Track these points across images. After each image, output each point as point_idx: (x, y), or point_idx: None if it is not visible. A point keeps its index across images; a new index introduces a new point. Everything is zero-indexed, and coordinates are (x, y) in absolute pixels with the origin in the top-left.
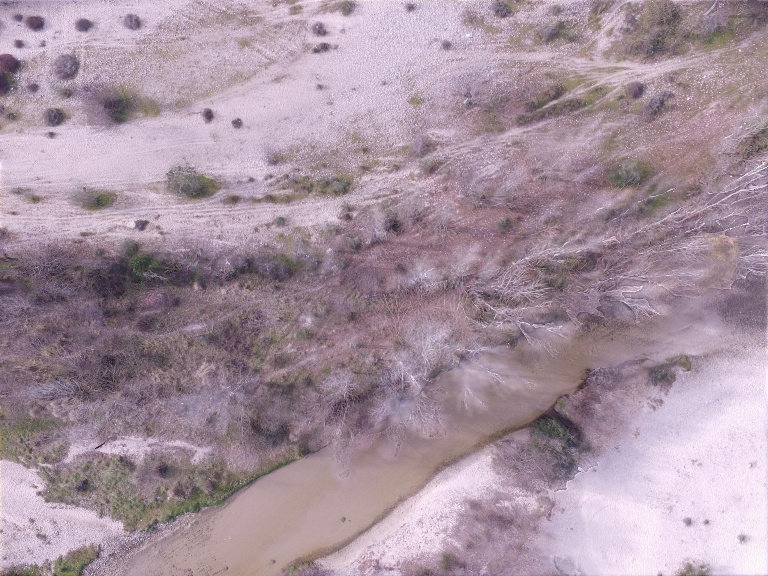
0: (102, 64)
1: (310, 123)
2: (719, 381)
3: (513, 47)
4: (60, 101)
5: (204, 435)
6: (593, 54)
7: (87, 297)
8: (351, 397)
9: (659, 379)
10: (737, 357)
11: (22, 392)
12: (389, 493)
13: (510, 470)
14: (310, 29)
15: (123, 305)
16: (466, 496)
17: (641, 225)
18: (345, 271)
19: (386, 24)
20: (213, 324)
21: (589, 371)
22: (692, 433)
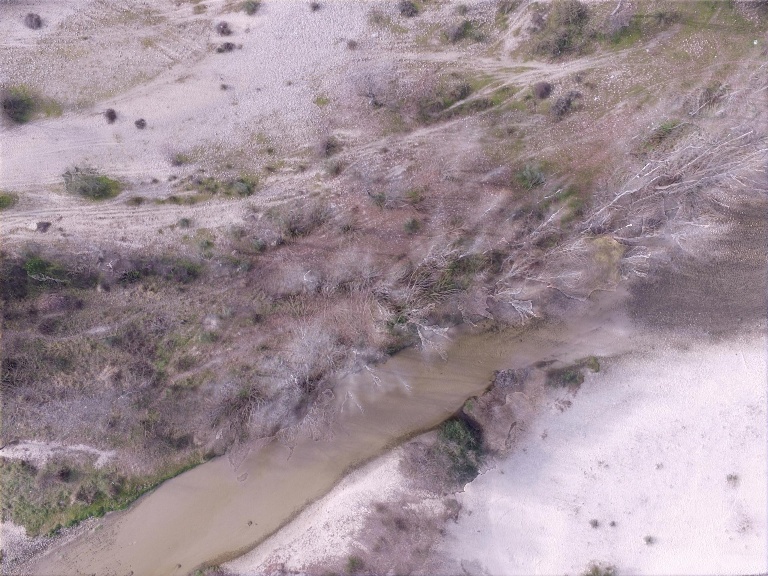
0: (3, 64)
1: (214, 124)
2: (627, 382)
3: (420, 47)
4: None
5: (108, 439)
6: (500, 54)
7: None
8: (256, 400)
9: (568, 380)
10: (645, 358)
11: None
12: (296, 496)
13: (416, 472)
14: (214, 29)
15: (23, 308)
16: (373, 499)
17: None
18: (251, 273)
19: (291, 24)
20: (117, 327)
21: (497, 373)
22: (599, 434)
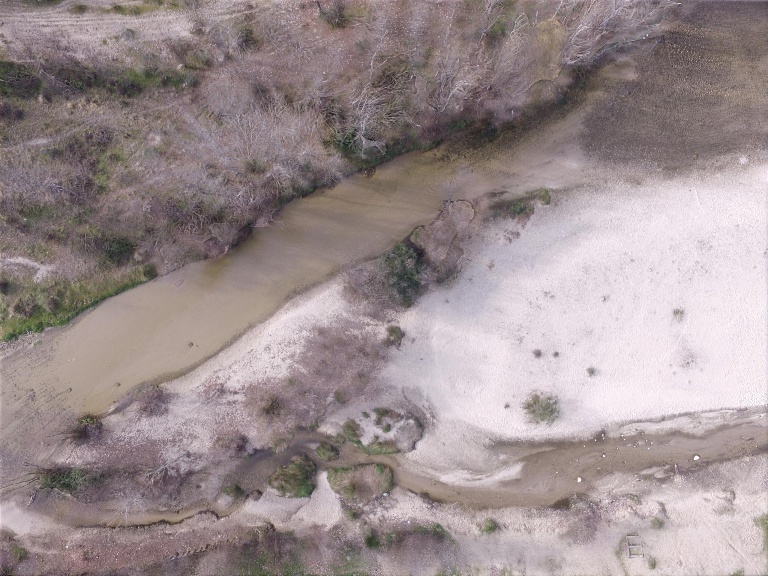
0: None
1: None
2: (578, 215)
3: None
4: None
5: (48, 253)
6: None
7: None
8: (199, 218)
9: (518, 212)
10: (598, 192)
11: None
12: (239, 320)
13: (360, 297)
14: None
15: None
16: (315, 323)
17: None
18: (197, 89)
19: None
20: (59, 139)
21: (446, 202)
22: (547, 266)
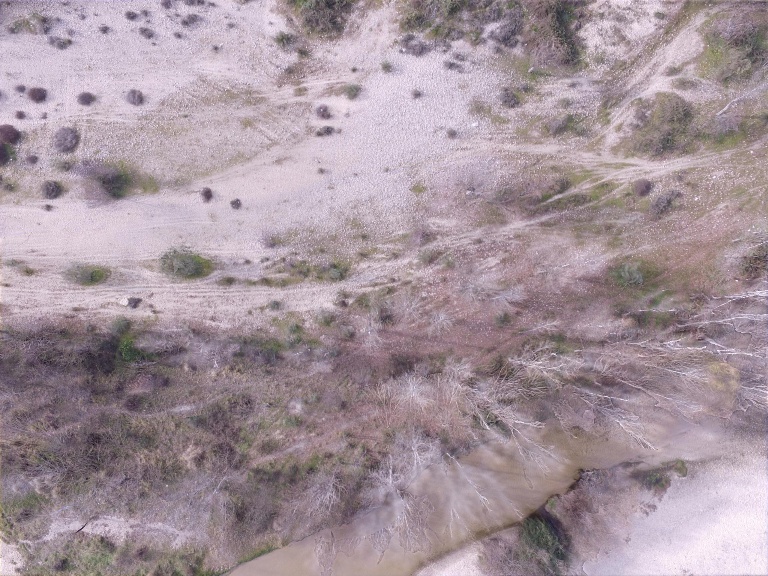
0: (103, 138)
1: (310, 207)
2: (715, 489)
3: (519, 138)
4: (59, 174)
5: (187, 519)
6: (601, 149)
7: (76, 373)
8: (338, 488)
9: (654, 483)
10: (735, 465)
11: (6, 466)
12: None
13: (496, 571)
14: (314, 111)
15: (111, 385)
16: None
17: (642, 326)
18: (338, 358)
19: (391, 110)
20: (202, 406)
21: (582, 472)
22: (685, 542)
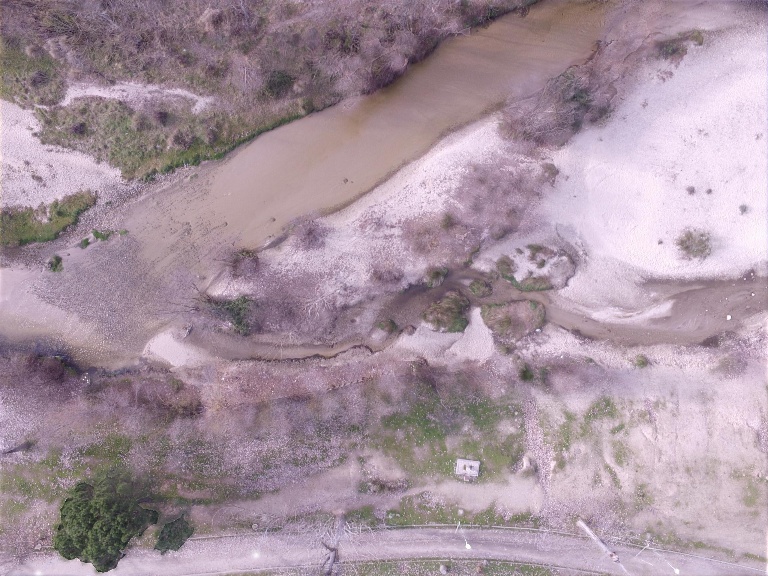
0: None
1: None
2: (730, 56)
3: None
4: None
5: (206, 84)
6: None
7: None
8: None
9: (670, 53)
10: (750, 33)
11: (18, 30)
12: (393, 157)
13: (516, 132)
14: None
15: None
16: (471, 160)
17: None
18: None
19: None
20: None
21: (600, 41)
22: (700, 104)
